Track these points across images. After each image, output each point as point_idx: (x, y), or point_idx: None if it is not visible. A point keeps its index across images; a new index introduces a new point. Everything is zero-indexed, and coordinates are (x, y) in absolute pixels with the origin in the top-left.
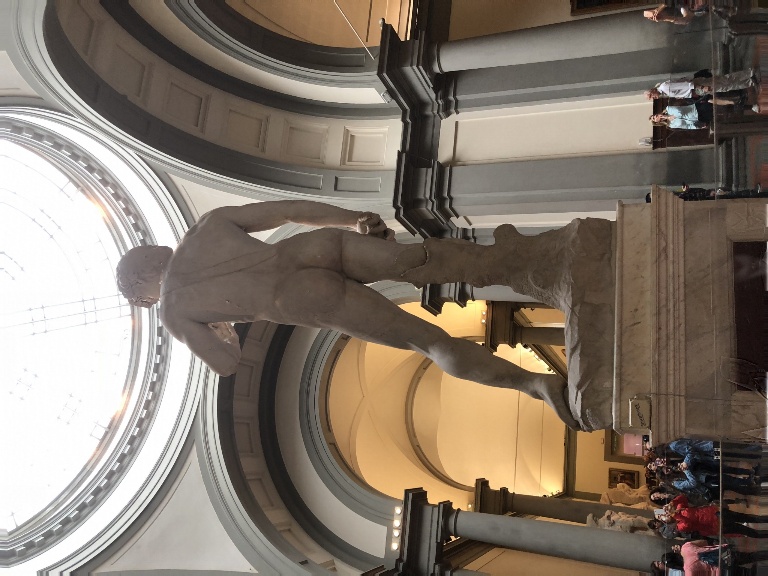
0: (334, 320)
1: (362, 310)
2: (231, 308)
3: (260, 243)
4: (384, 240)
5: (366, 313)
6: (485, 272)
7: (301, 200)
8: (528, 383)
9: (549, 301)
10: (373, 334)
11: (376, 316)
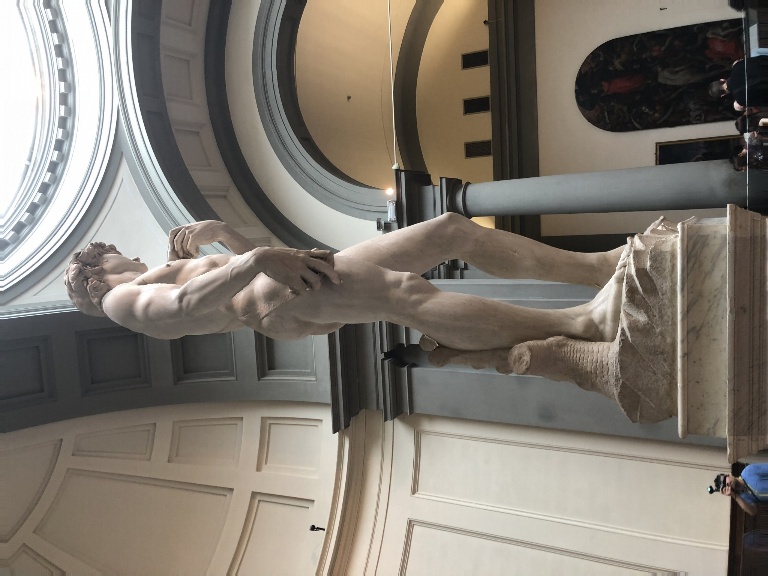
0: None
1: None
2: None
3: (211, 316)
4: (349, 311)
5: None
6: None
7: (195, 311)
8: None
9: None
10: None
11: None
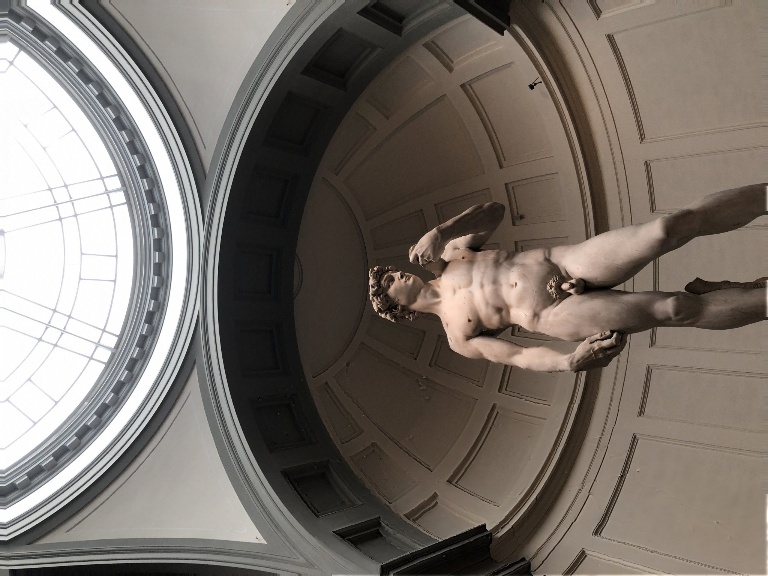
0: None
1: None
2: None
3: None
4: None
5: None
6: None
7: None
8: None
9: None
10: None
11: None
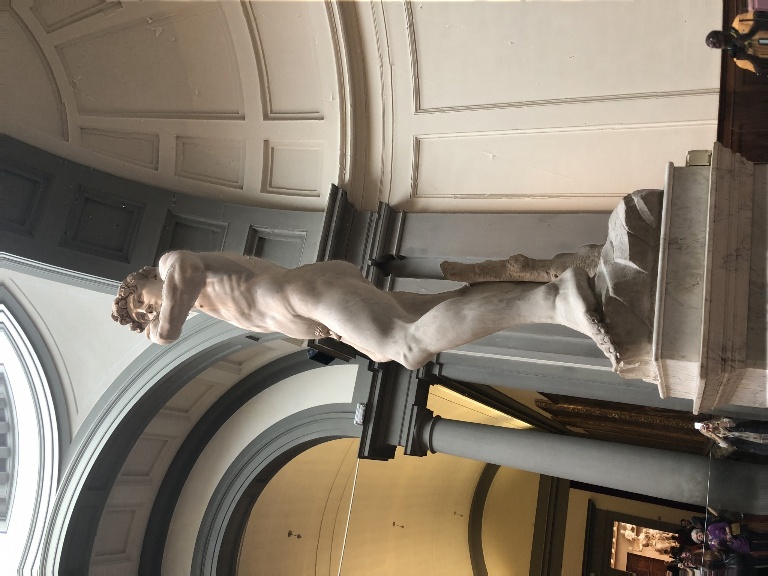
0: (337, 283)
1: None
2: (246, 261)
3: None
4: None
5: (375, 288)
6: None
7: None
8: None
9: (591, 265)
10: (366, 300)
11: None
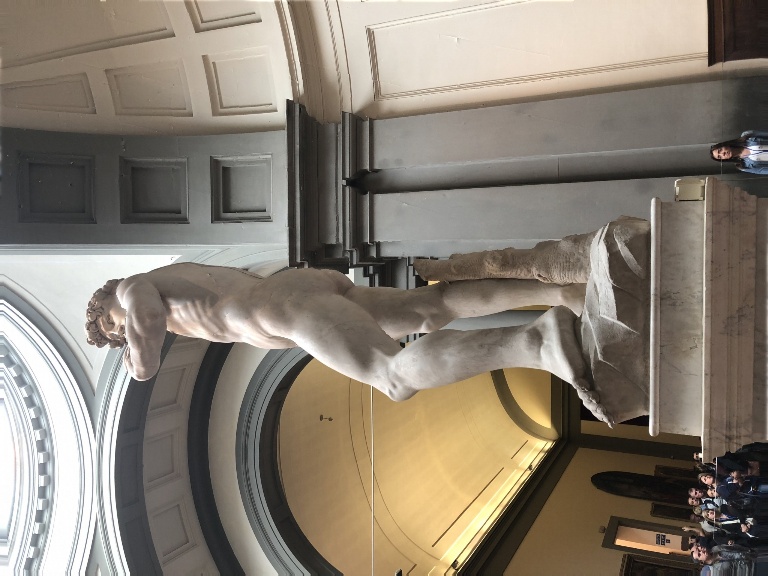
0: (307, 304)
1: (345, 302)
2: (206, 280)
3: None
4: None
5: (347, 305)
6: (510, 251)
7: None
8: (526, 325)
9: (577, 266)
10: (340, 326)
11: (356, 311)
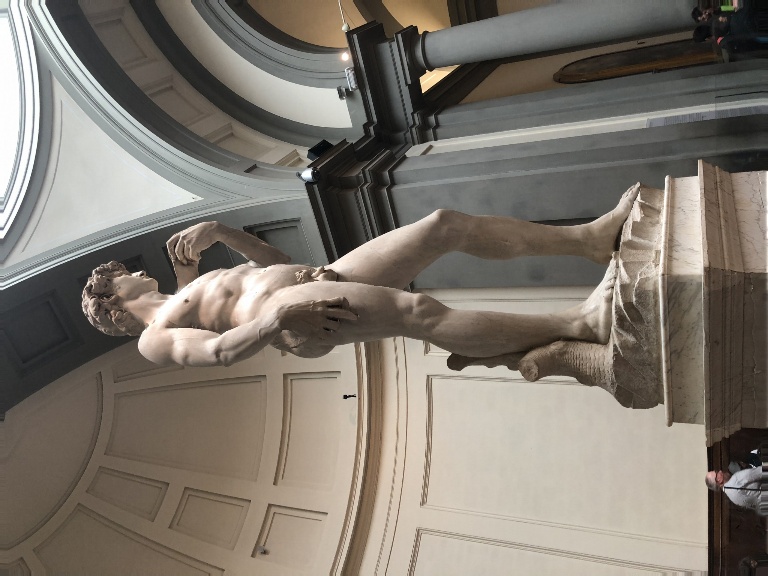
0: None
1: None
2: None
3: None
4: (370, 337)
5: None
6: None
7: None
8: None
9: None
10: None
11: None
